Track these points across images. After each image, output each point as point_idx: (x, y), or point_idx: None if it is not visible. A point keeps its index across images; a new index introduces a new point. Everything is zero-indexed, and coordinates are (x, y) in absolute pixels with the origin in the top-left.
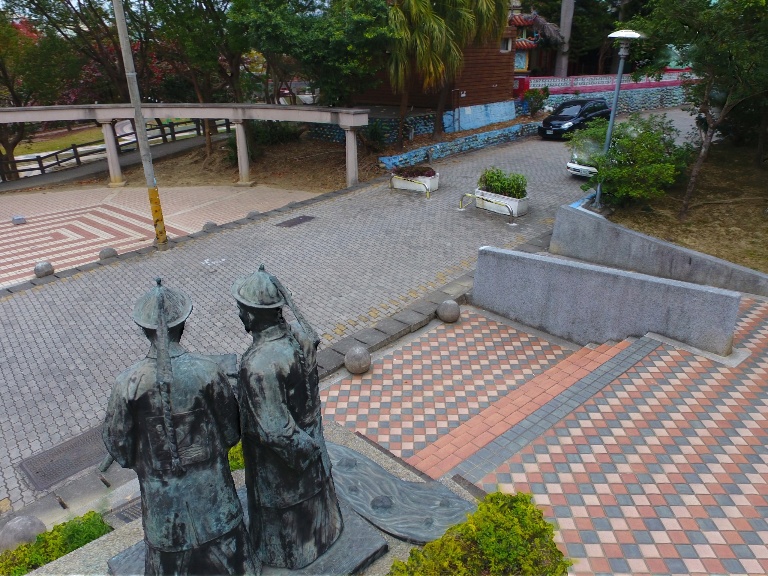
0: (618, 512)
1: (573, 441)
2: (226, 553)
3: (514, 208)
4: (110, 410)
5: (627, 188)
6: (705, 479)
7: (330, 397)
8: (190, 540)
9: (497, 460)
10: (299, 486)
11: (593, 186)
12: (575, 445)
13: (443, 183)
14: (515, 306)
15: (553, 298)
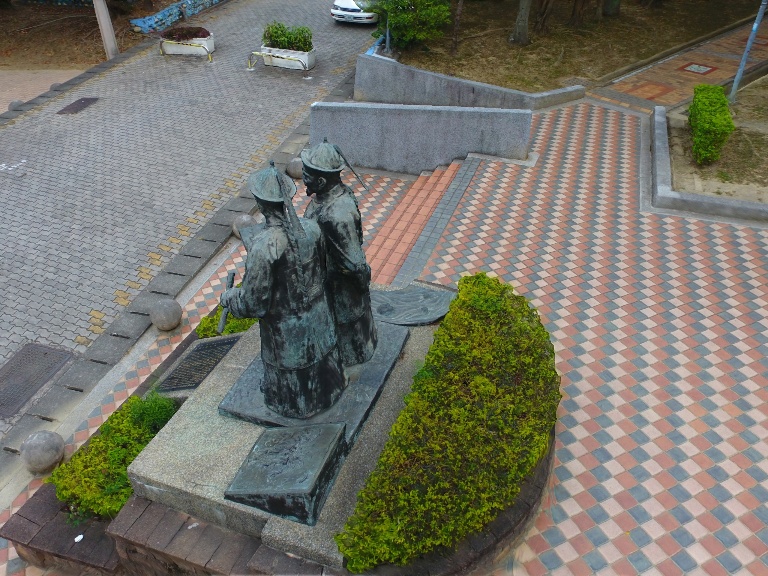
0: (511, 277)
1: (460, 242)
2: (336, 359)
3: (305, 62)
4: (254, 273)
5: (413, 32)
6: (550, 243)
7: (237, 264)
8: (318, 355)
9: (419, 268)
10: (362, 302)
11: (383, 33)
12: (463, 244)
13: (216, 43)
14: (353, 153)
15: (387, 139)
